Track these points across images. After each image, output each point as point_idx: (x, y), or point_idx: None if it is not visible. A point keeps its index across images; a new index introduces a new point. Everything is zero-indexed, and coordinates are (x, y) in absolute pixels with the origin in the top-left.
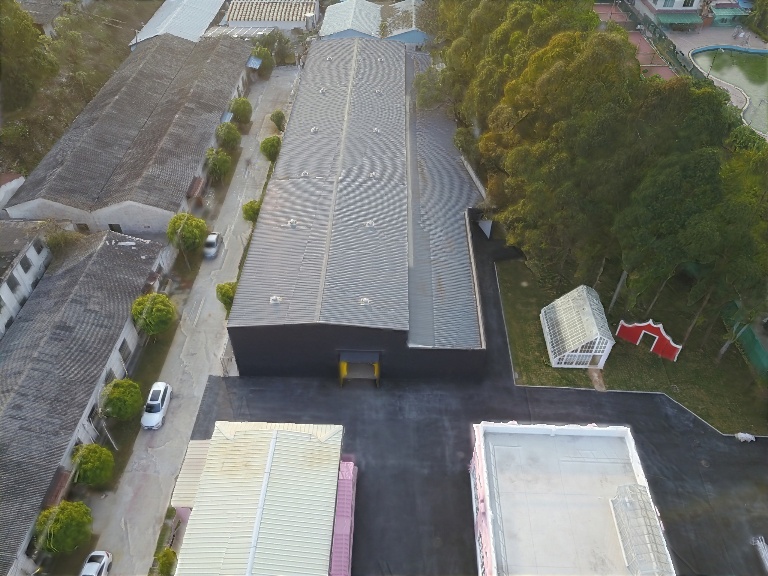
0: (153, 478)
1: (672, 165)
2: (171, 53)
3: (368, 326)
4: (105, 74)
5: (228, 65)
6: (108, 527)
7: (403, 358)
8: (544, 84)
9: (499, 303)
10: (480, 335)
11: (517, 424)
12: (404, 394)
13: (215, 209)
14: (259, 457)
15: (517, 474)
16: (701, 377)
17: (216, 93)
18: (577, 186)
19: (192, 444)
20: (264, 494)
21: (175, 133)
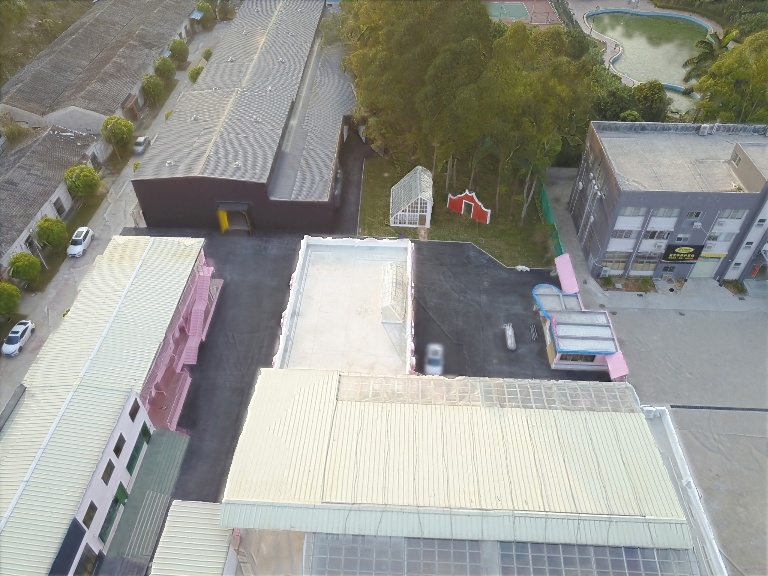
0: (72, 285)
1: (445, 51)
2: (126, 6)
3: (235, 179)
4: (71, 24)
5: (172, 15)
6: (35, 311)
7: (268, 210)
8: (371, 0)
9: (360, 185)
10: (328, 194)
11: (331, 238)
12: (270, 239)
13: (148, 122)
14: (139, 252)
15: (323, 266)
16: (504, 234)
17: (158, 35)
18: (395, 77)
19: (99, 257)
20: (137, 270)
21: (118, 62)
